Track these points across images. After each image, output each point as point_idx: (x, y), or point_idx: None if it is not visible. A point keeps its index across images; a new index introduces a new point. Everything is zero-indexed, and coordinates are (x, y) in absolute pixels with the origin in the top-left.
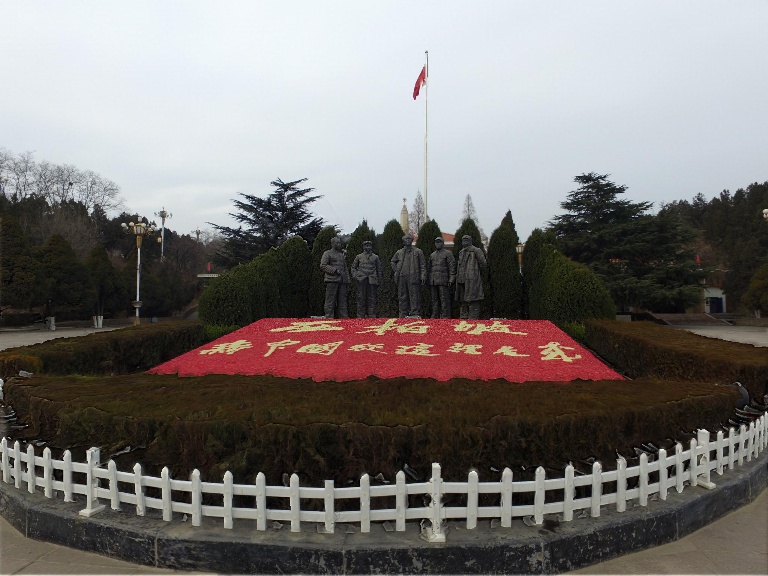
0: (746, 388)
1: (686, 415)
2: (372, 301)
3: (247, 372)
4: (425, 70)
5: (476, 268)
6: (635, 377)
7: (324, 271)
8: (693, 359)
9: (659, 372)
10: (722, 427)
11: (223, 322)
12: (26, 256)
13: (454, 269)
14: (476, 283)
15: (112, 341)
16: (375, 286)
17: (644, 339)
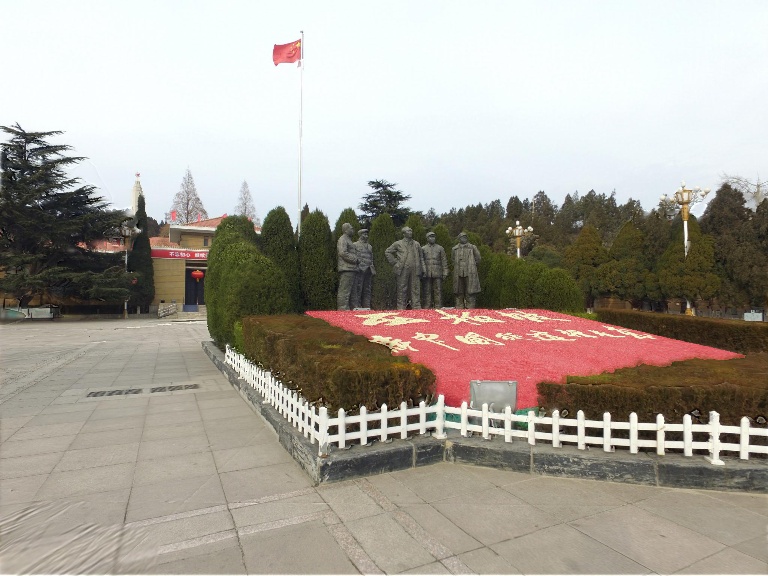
0: None
1: None
2: (369, 292)
3: (503, 366)
4: (300, 50)
5: (475, 263)
6: None
7: (339, 259)
8: None
9: (733, 342)
10: None
11: None
12: None
13: (447, 263)
14: (476, 277)
15: (354, 341)
16: None
17: (707, 320)
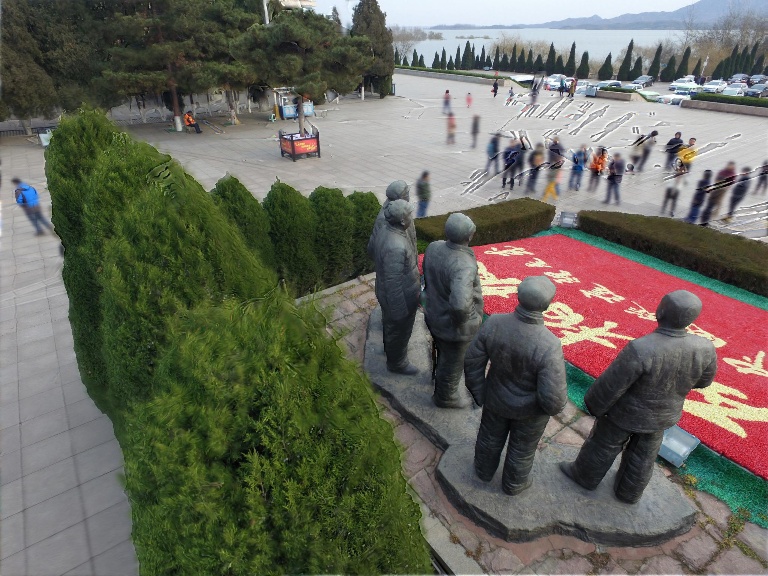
0: None
1: None
2: None
3: None
4: None
5: None
6: (503, 241)
7: None
8: (541, 213)
9: None
10: None
11: None
12: None
13: None
14: None
15: None
16: None
17: (511, 218)
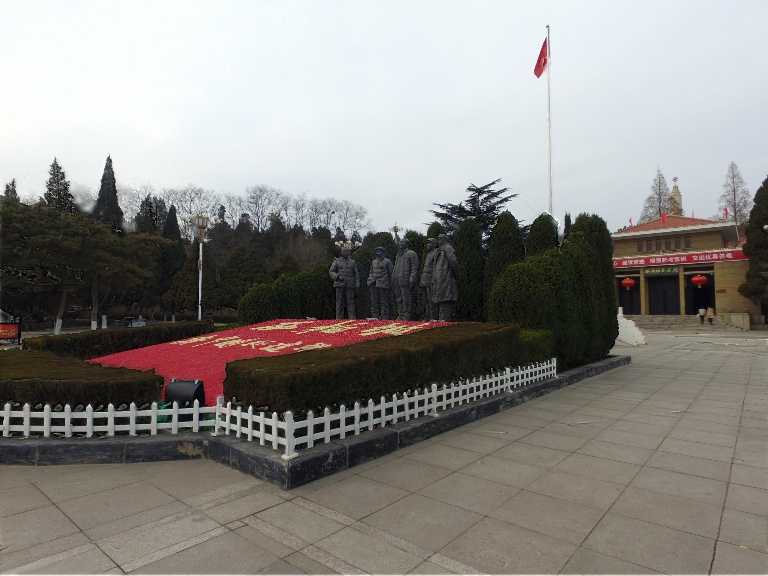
0: (225, 388)
1: (14, 390)
2: (382, 303)
3: None
4: (546, 47)
5: (444, 268)
6: None
7: None
8: None
9: None
10: (75, 408)
11: (247, 322)
12: (262, 273)
13: None
14: (443, 283)
15: (112, 333)
16: (384, 289)
17: None
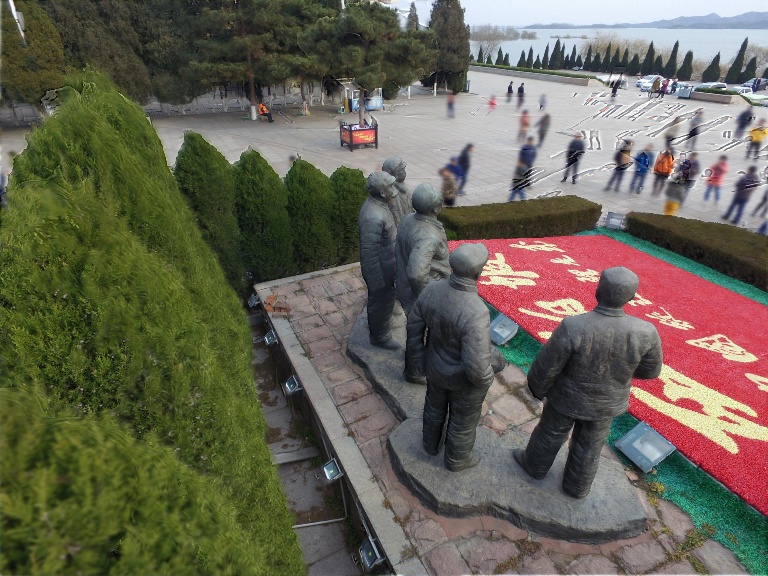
0: None
1: None
2: None
3: None
4: None
5: None
6: (538, 237)
7: None
8: (584, 211)
9: None
10: None
11: None
12: None
13: None
14: None
15: None
16: None
17: (548, 214)
